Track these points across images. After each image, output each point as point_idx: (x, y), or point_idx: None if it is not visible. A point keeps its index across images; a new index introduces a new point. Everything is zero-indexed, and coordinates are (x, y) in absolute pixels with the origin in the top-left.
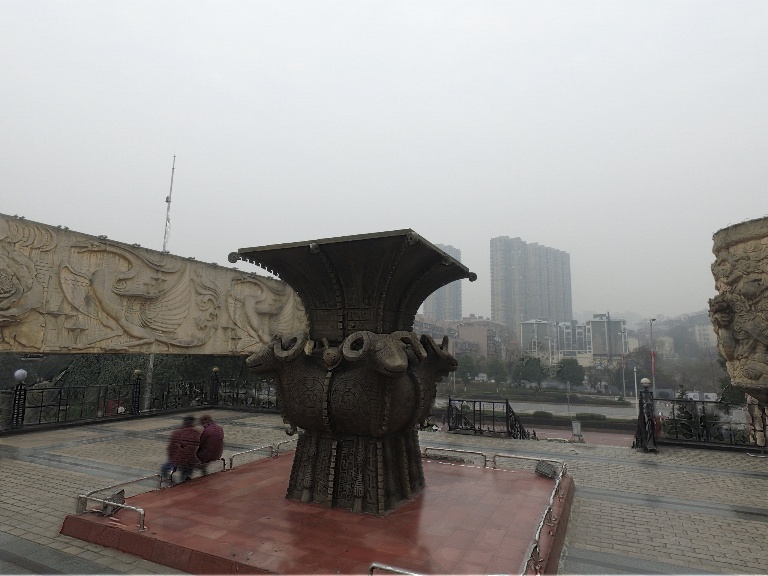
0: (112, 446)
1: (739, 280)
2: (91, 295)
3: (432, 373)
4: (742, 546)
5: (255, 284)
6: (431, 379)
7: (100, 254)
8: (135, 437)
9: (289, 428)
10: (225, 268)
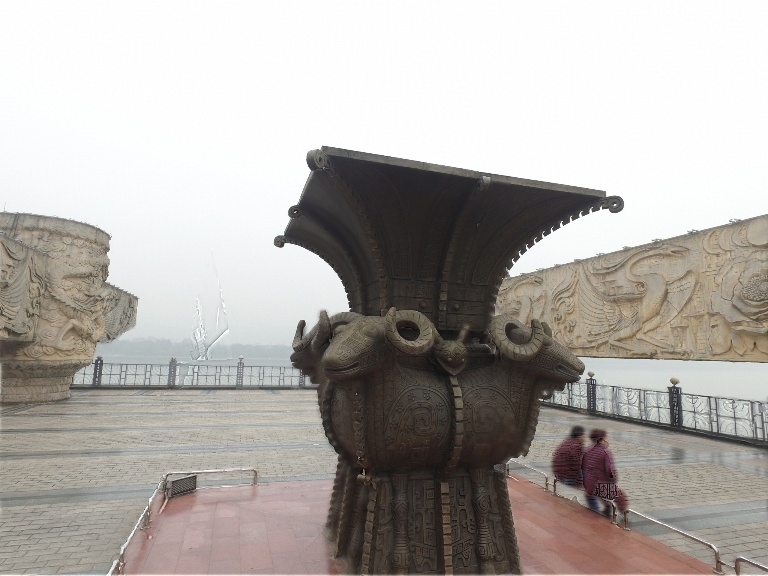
0: None
1: None
2: None
3: None
4: None
5: None
6: None
7: None
8: None
9: None
10: None
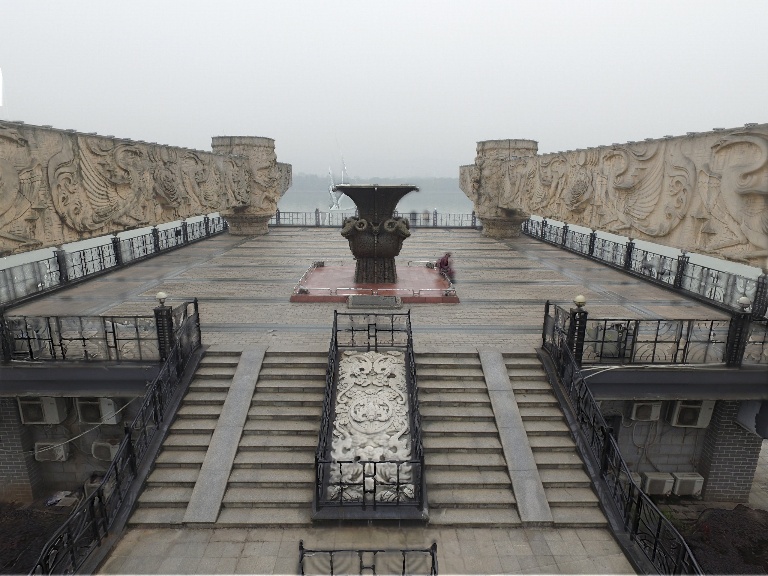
0: None
1: None
2: None
3: None
4: (246, 288)
5: (751, 143)
6: None
7: (614, 158)
8: None
9: None
10: (705, 134)
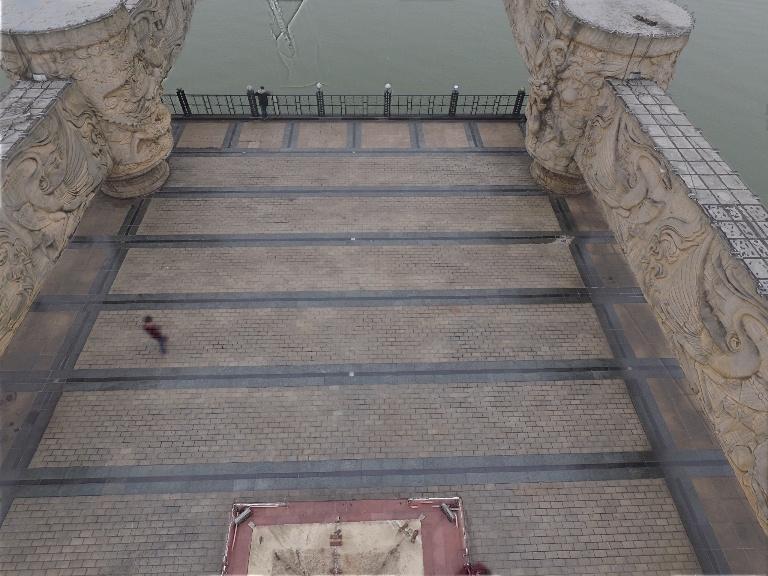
0: None
1: None
2: None
3: None
4: None
5: None
6: None
7: None
8: None
9: None
10: None
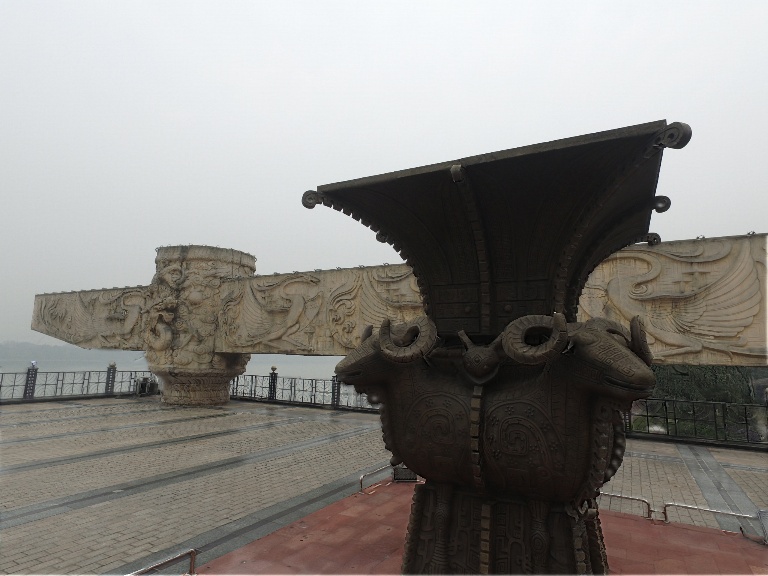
0: (634, 463)
1: None
2: (610, 305)
3: (559, 396)
4: None
5: None
6: (555, 408)
7: (613, 263)
8: (687, 464)
9: None
10: None
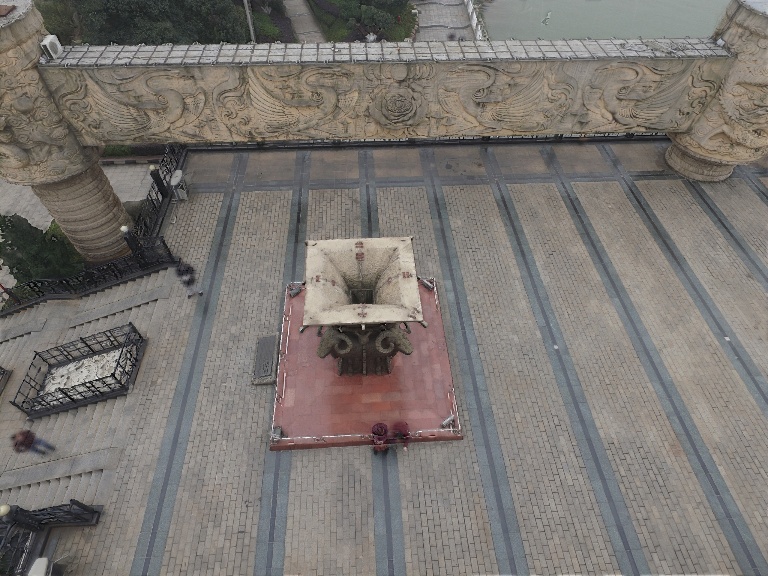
0: None
1: (4, 96)
2: None
3: None
4: None
5: None
6: None
7: None
8: None
9: (143, 570)
10: None
